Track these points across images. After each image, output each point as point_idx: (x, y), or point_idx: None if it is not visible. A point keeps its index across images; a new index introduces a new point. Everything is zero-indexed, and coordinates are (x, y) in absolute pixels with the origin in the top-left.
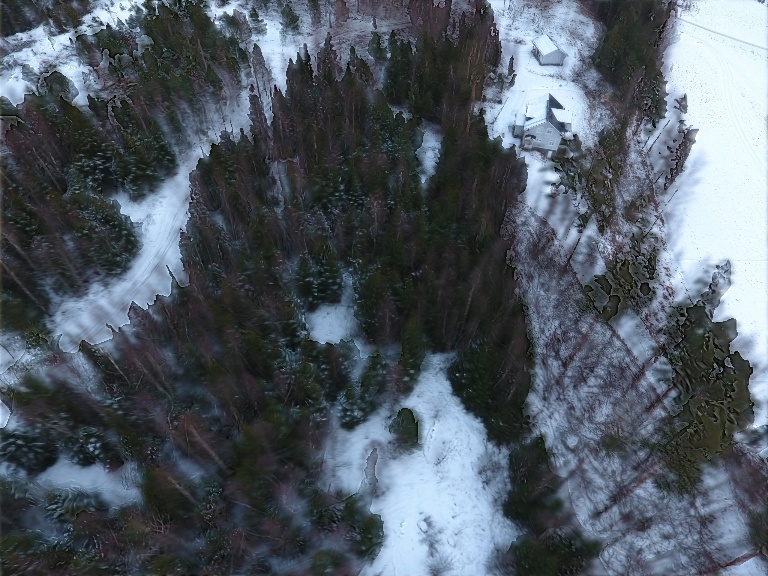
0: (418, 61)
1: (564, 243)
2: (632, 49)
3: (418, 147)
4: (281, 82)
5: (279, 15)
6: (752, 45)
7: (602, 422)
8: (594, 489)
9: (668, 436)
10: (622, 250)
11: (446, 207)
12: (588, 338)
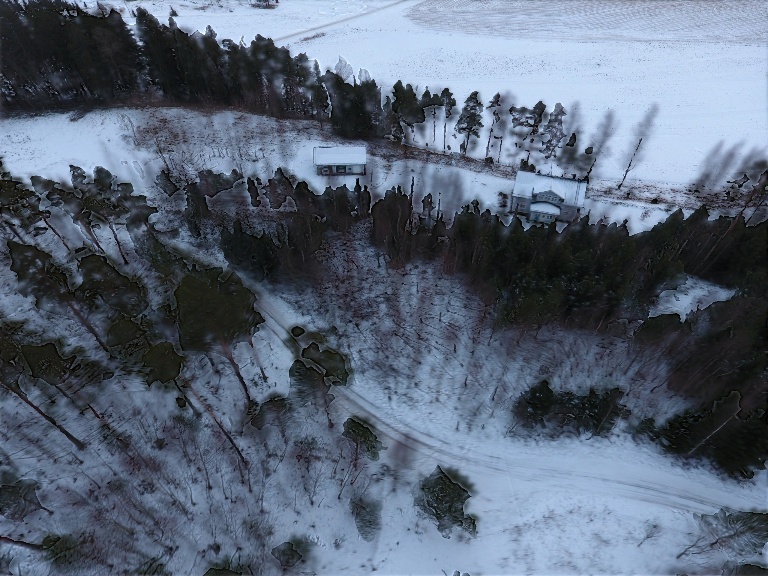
0: (572, 259)
1: None
2: None
3: None
4: (653, 512)
5: (281, 575)
6: None
7: None
8: None
9: None
10: None
11: None
12: None
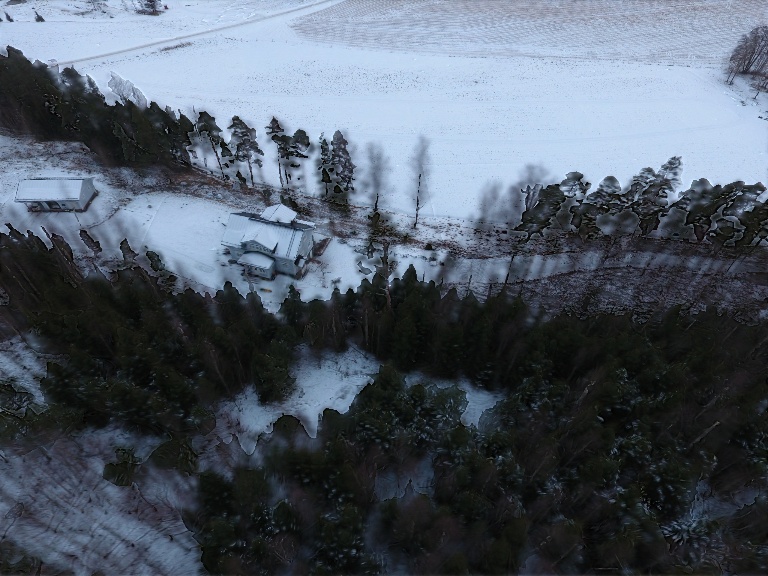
0: (141, 348)
1: (462, 280)
2: (156, 119)
3: (405, 382)
4: None
5: None
6: (93, 58)
7: (688, 302)
8: (762, 318)
9: (654, 272)
10: (442, 244)
11: (620, 345)
12: (595, 291)
